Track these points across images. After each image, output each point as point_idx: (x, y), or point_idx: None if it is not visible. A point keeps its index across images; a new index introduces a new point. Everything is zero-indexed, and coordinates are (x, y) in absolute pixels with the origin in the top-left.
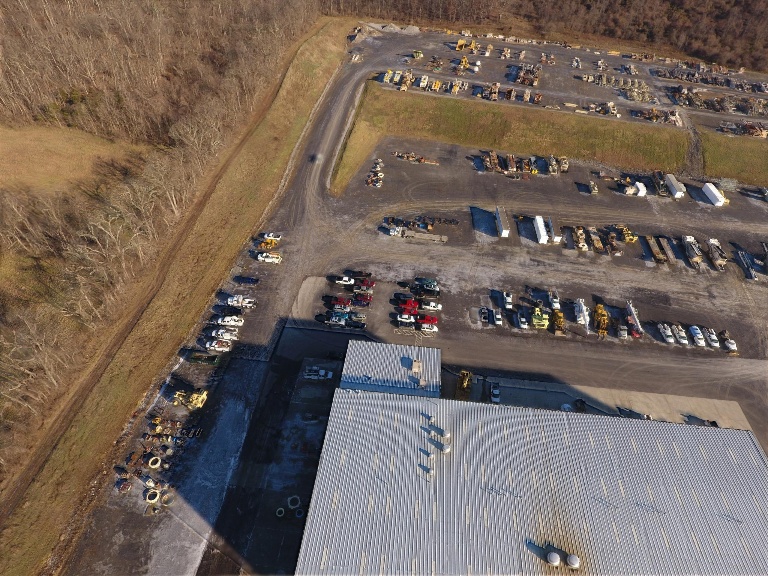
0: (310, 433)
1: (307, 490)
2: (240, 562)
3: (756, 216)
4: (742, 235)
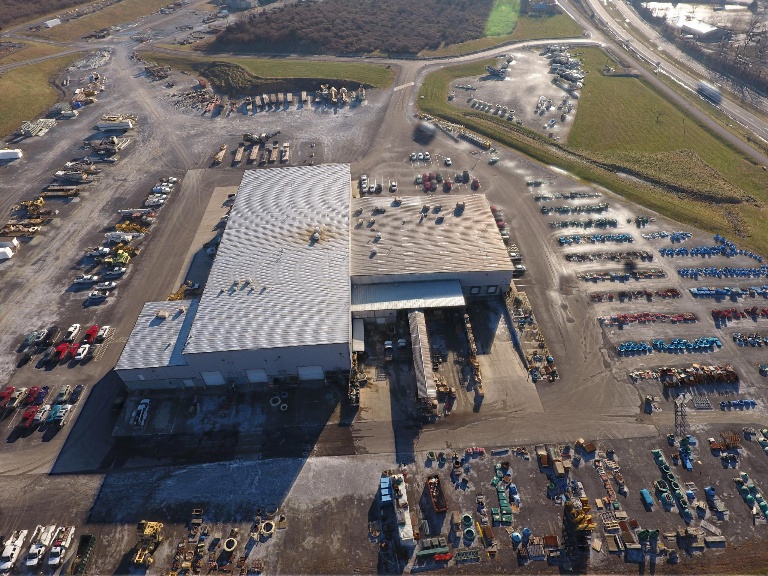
0: (210, 406)
1: (265, 395)
2: (322, 426)
3: (47, 144)
4: (65, 155)
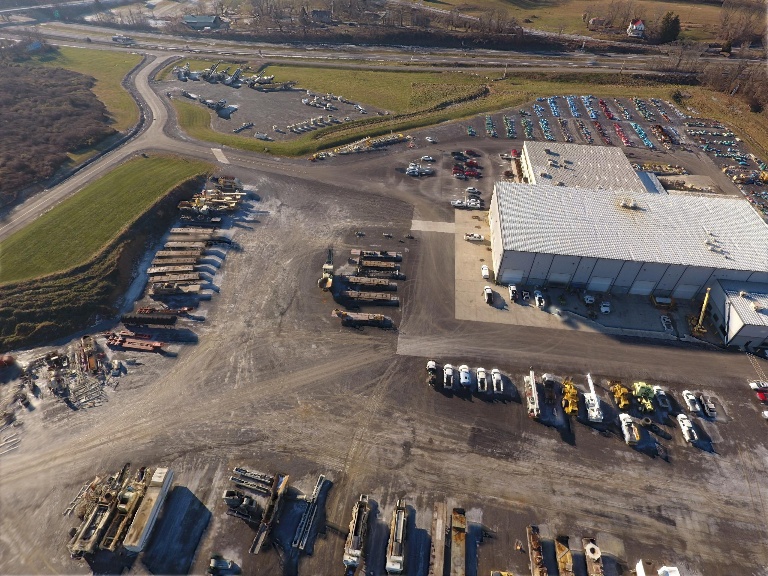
0: None
1: None
2: None
3: None
4: None
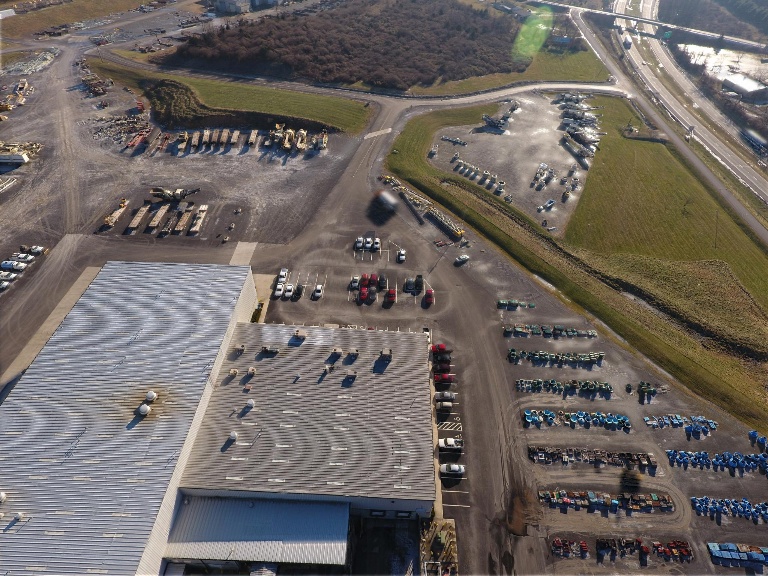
0: None
1: None
2: None
3: None
4: None
